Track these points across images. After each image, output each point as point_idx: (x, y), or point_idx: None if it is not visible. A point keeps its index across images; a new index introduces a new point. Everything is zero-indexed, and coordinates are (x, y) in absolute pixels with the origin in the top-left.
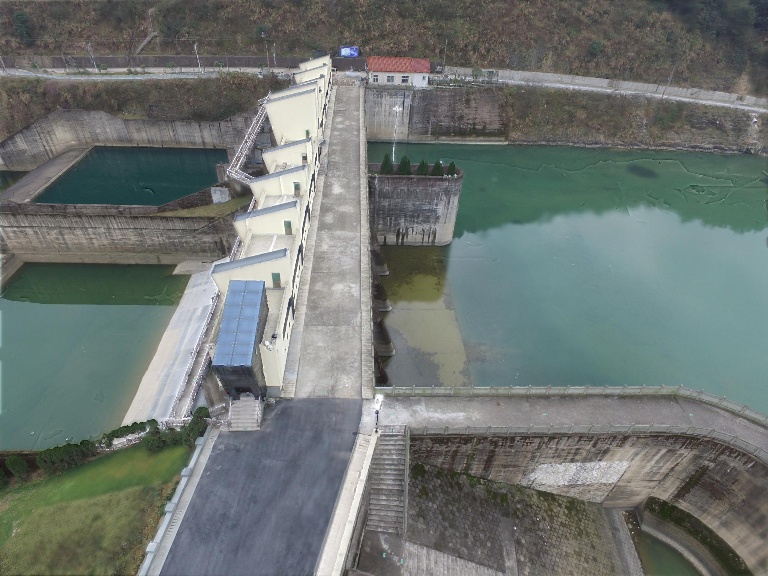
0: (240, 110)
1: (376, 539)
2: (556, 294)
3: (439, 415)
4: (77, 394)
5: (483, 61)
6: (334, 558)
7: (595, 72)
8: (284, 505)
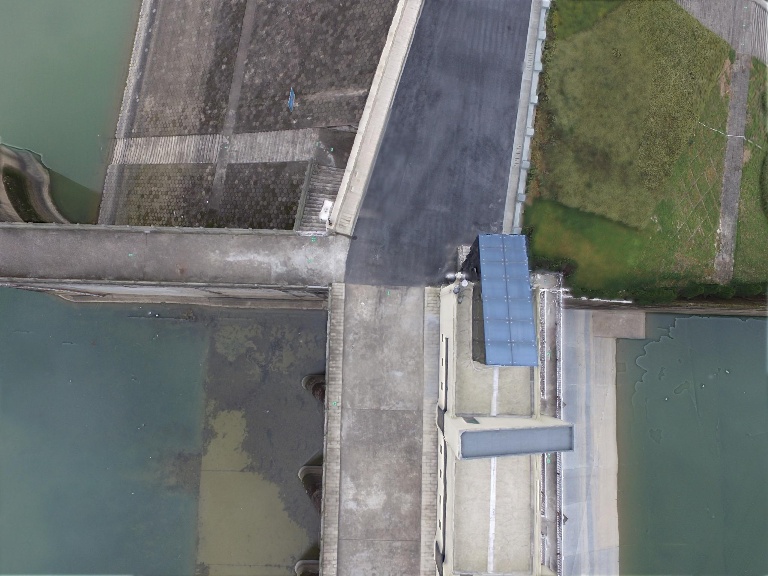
0: None
1: (339, 162)
2: None
3: (257, 258)
4: (684, 449)
5: None
6: (375, 116)
7: None
8: (423, 166)
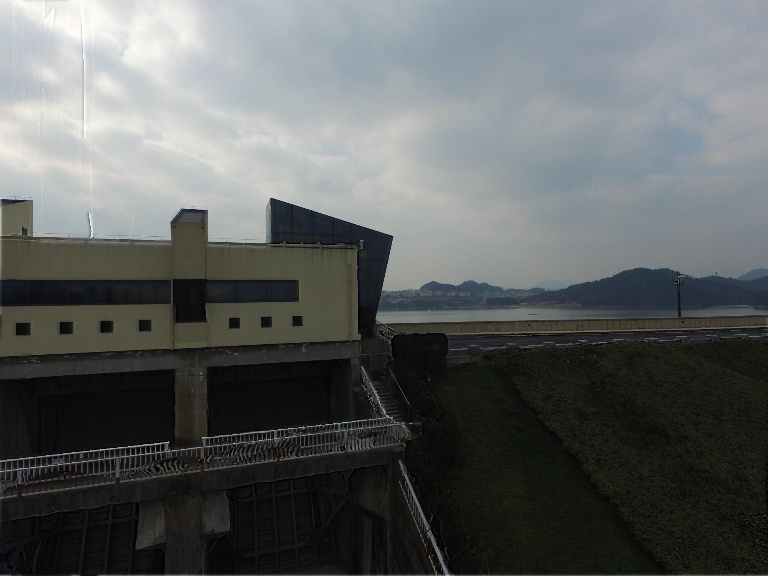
0: None
1: None
2: None
3: None
4: None
5: None
6: (464, 333)
7: None
8: None
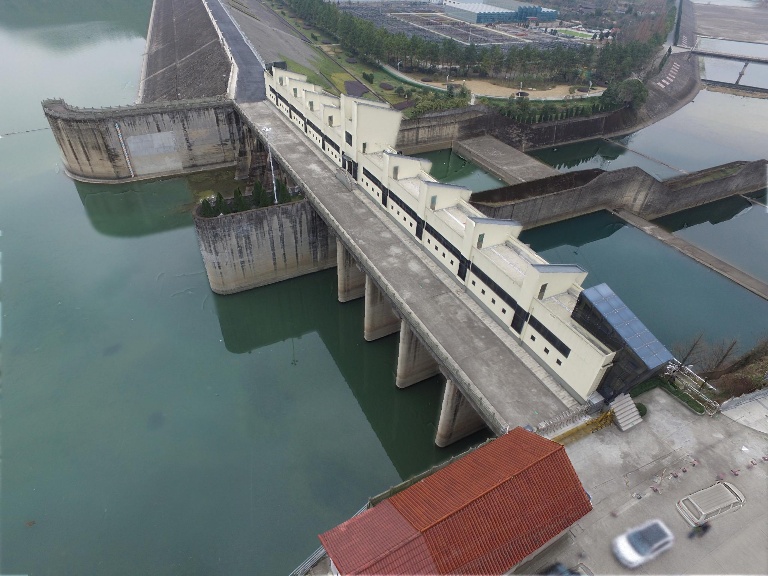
0: None
1: None
2: (102, 264)
3: None
4: None
5: None
6: None
7: None
8: None
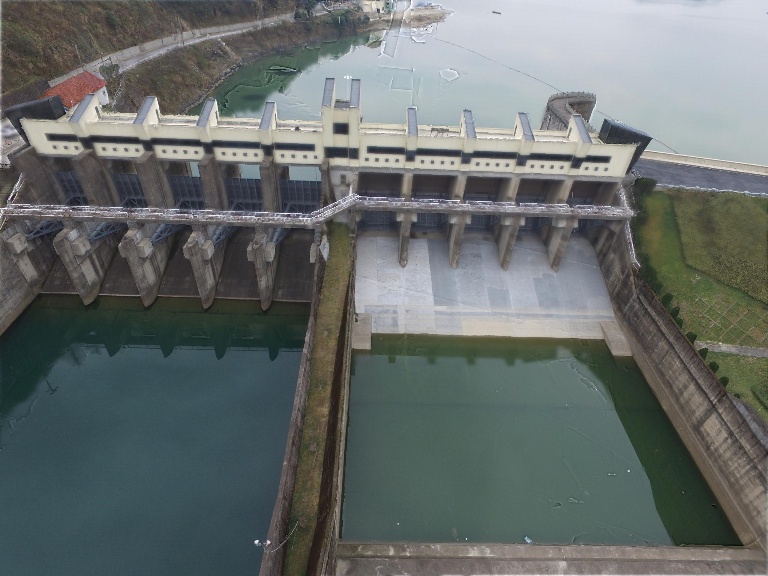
0: None
1: None
2: None
3: None
4: (537, 394)
5: (66, 62)
6: None
7: (126, 42)
8: None
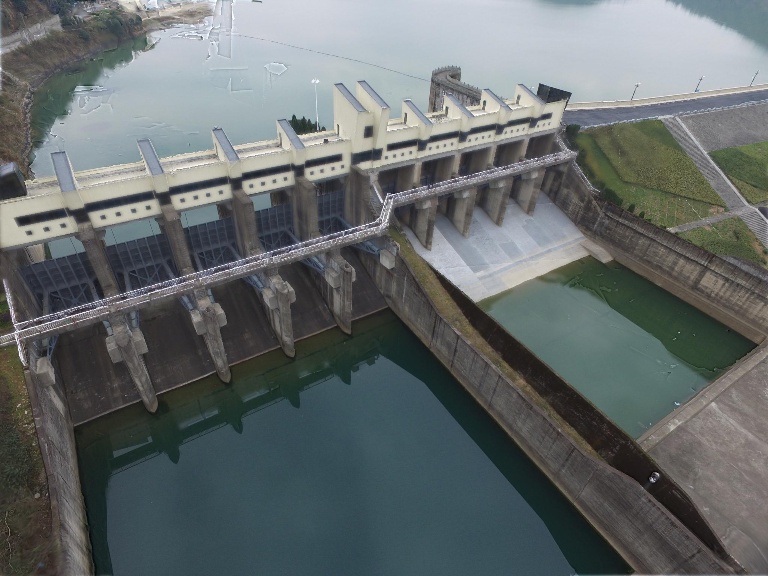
0: (3, 435)
1: None
2: None
3: None
4: None
5: None
6: None
7: None
8: None
